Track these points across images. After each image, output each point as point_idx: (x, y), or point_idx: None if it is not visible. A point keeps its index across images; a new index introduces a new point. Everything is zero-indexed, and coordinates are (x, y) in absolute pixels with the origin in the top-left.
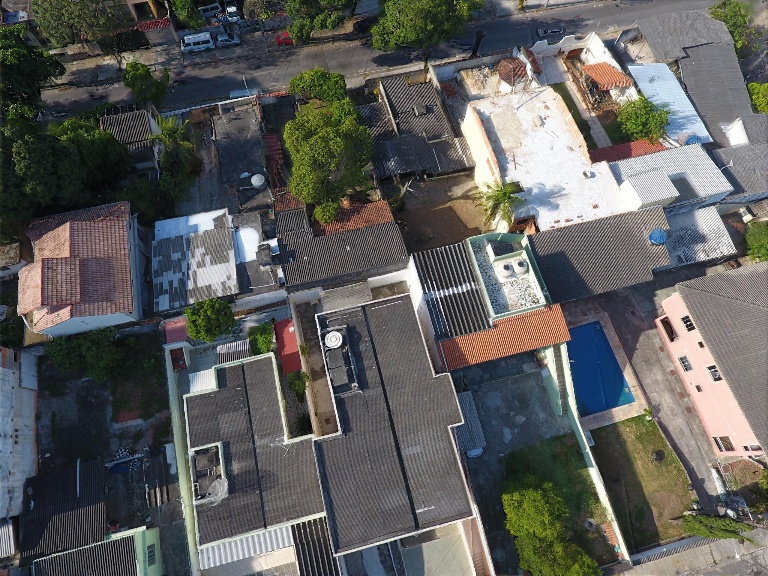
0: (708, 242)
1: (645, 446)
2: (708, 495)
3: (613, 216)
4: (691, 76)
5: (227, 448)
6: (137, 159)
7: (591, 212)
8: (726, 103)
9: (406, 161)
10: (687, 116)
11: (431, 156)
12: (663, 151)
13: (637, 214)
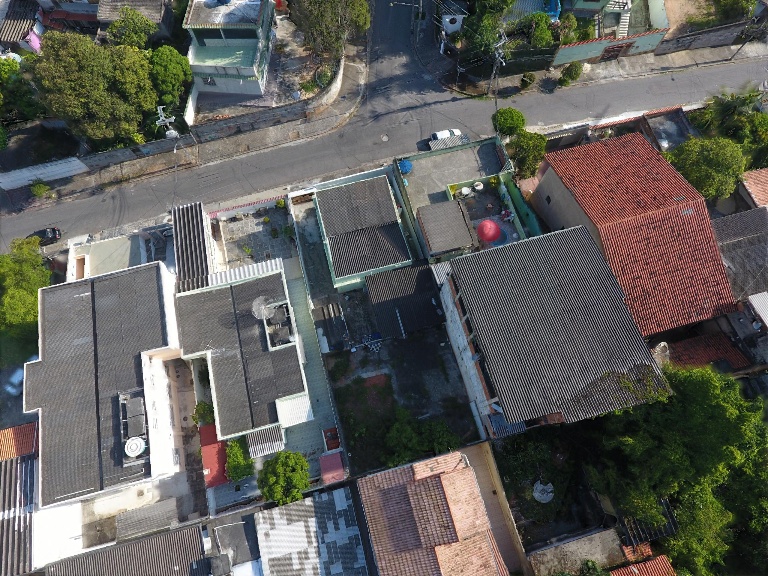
0: None
1: None
2: None
3: None
4: None
5: (264, 346)
6: None
7: None
8: None
9: None
10: None
11: None
12: None
13: None
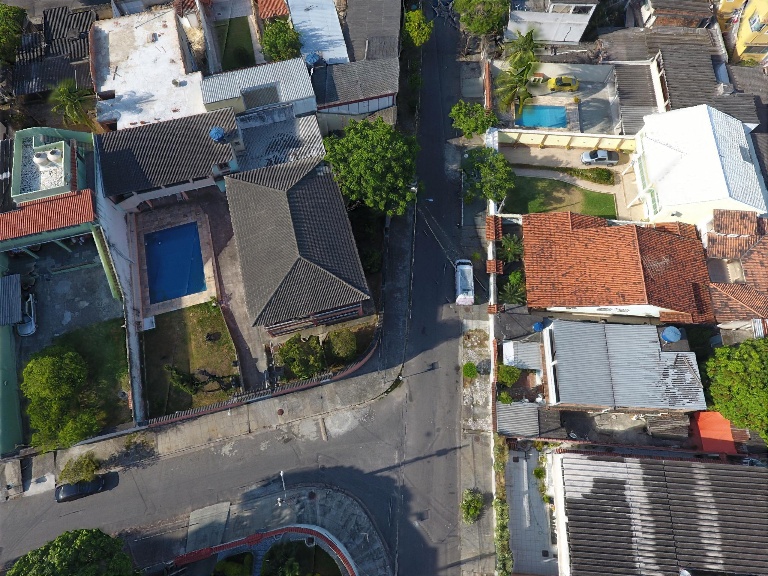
0: (301, 147)
1: (204, 329)
2: (258, 373)
3: (184, 117)
4: (353, 6)
5: None
6: None
7: (170, 115)
8: (377, 29)
9: (47, 81)
10: (331, 40)
11: (72, 76)
12: (268, 64)
13: (208, 115)
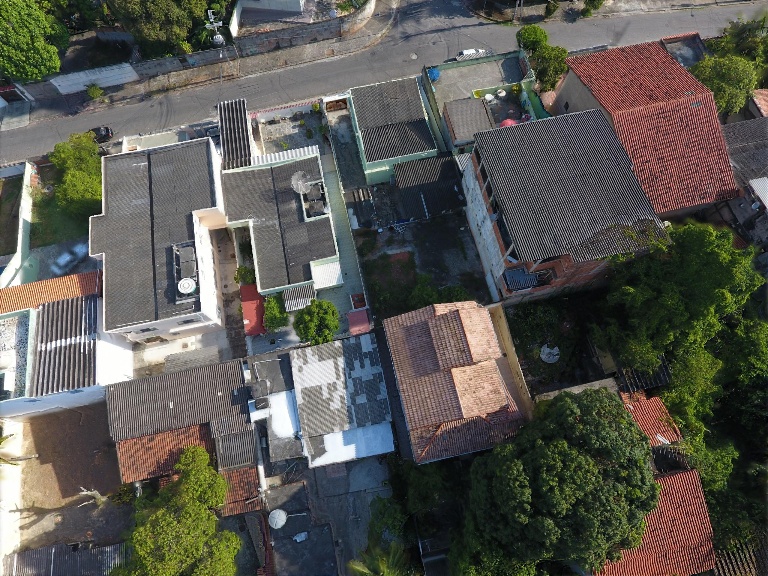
0: None
1: None
2: None
3: None
4: None
5: (301, 218)
6: (445, 568)
7: None
8: None
9: (94, 567)
10: None
11: (58, 575)
12: None
13: None
